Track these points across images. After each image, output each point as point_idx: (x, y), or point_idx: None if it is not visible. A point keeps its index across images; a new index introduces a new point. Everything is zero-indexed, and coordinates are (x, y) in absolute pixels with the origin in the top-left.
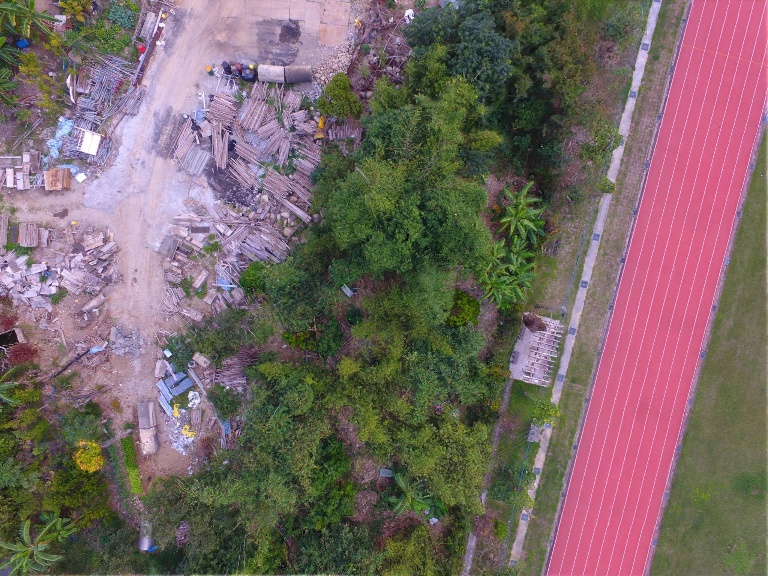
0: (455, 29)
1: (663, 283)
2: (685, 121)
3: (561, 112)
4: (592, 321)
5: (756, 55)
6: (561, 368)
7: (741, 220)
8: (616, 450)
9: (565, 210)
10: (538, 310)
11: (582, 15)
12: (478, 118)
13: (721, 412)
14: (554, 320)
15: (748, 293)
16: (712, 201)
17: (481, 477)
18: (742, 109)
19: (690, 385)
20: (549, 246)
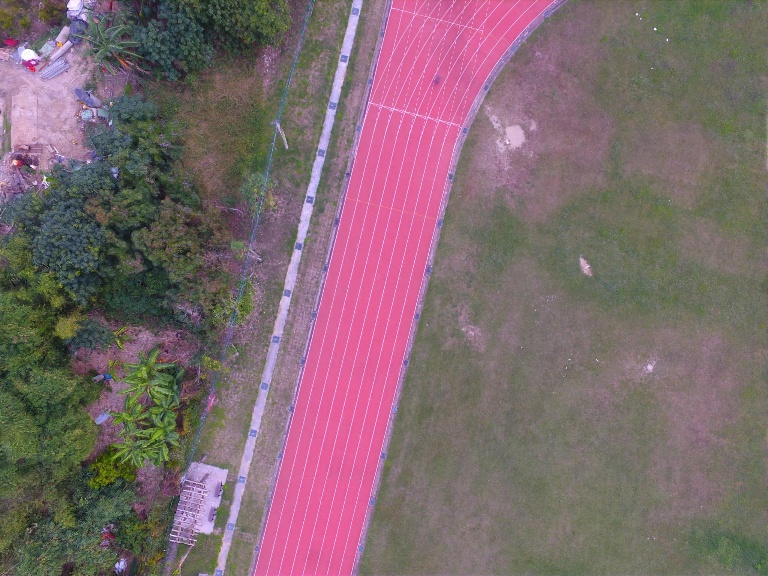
0: (35, 221)
1: (331, 431)
2: (351, 272)
3: (176, 287)
4: (261, 470)
5: (419, 208)
6: (231, 517)
7: (408, 369)
8: None
9: (232, 361)
10: (206, 460)
11: (242, 171)
12: (74, 301)
13: (391, 559)
14: (223, 469)
15: (416, 441)
16: (379, 350)
17: None
18: (407, 260)
19: (360, 532)
20: (217, 396)
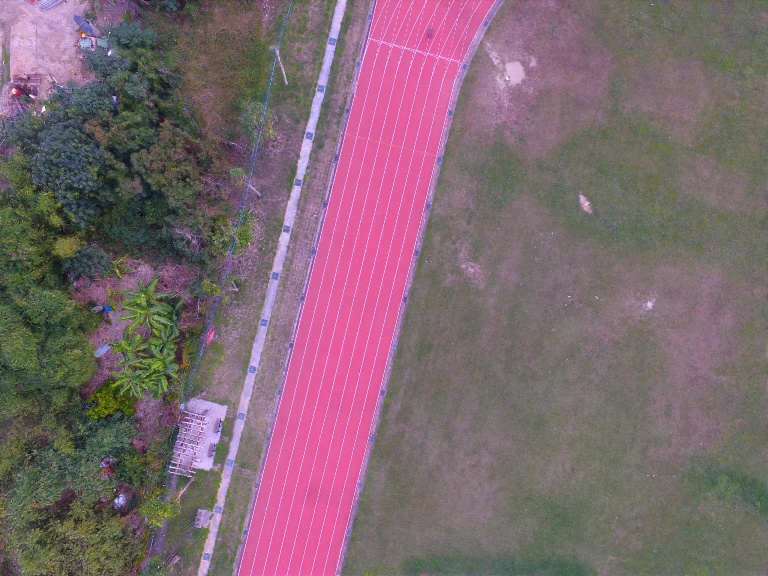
0: (34, 139)
1: (331, 368)
2: (350, 209)
3: (175, 212)
4: (261, 406)
5: (419, 144)
6: (230, 453)
7: (407, 306)
8: (286, 535)
9: (231, 296)
10: (205, 396)
11: None
12: (73, 223)
13: (390, 496)
14: (222, 405)
15: (415, 377)
16: (378, 287)
17: (119, 571)
18: (406, 197)
19: (360, 469)
20: (216, 332)
